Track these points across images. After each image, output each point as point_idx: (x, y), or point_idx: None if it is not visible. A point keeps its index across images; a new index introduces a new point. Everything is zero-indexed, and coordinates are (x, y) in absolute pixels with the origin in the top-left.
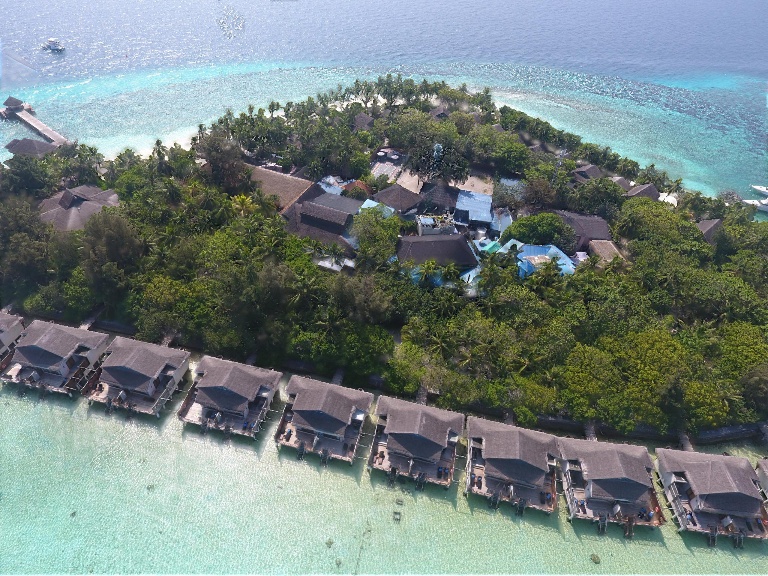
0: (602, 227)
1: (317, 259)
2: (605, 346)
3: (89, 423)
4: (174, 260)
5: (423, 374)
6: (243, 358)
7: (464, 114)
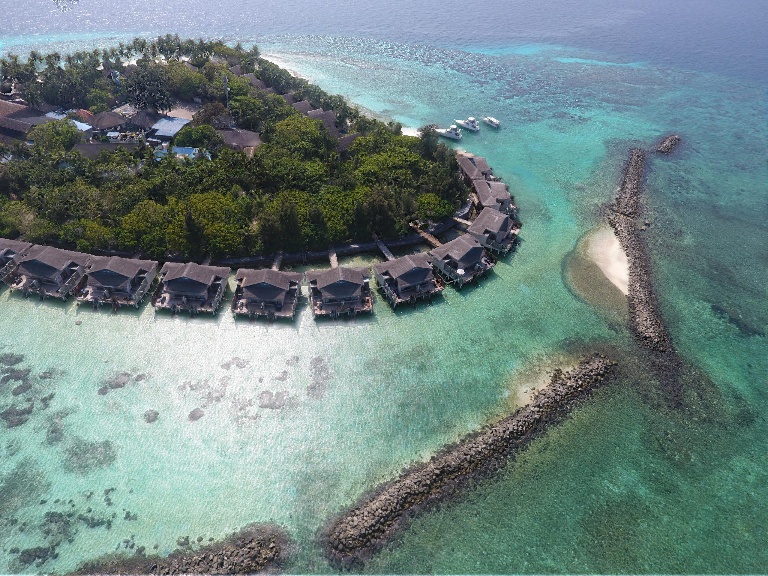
0: None
1: None
2: (168, 202)
3: None
4: None
5: (14, 219)
6: None
7: (217, 64)
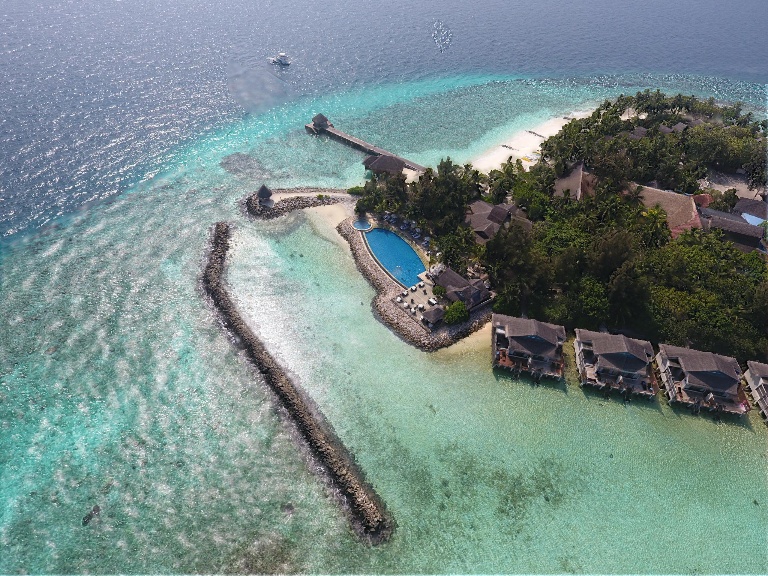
0: None
1: None
2: None
3: (686, 422)
4: (671, 273)
5: None
6: (766, 363)
7: None
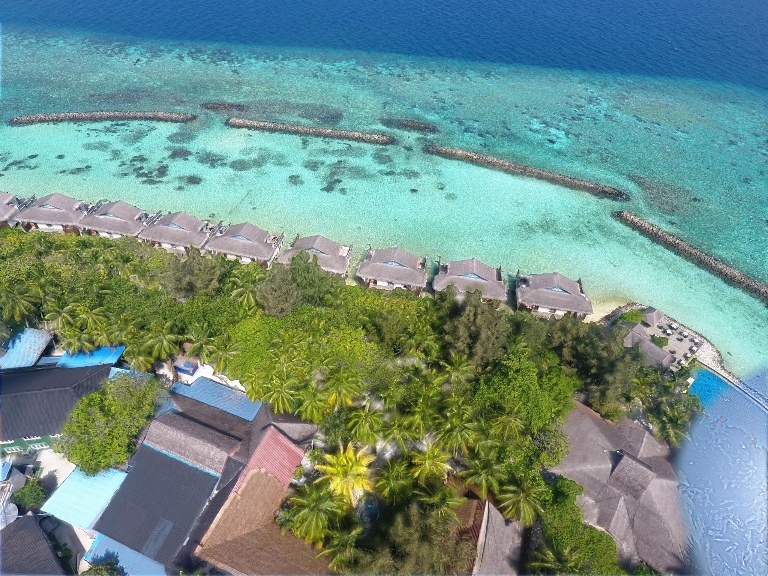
0: None
1: None
2: None
3: None
4: None
5: (157, 249)
6: None
7: None
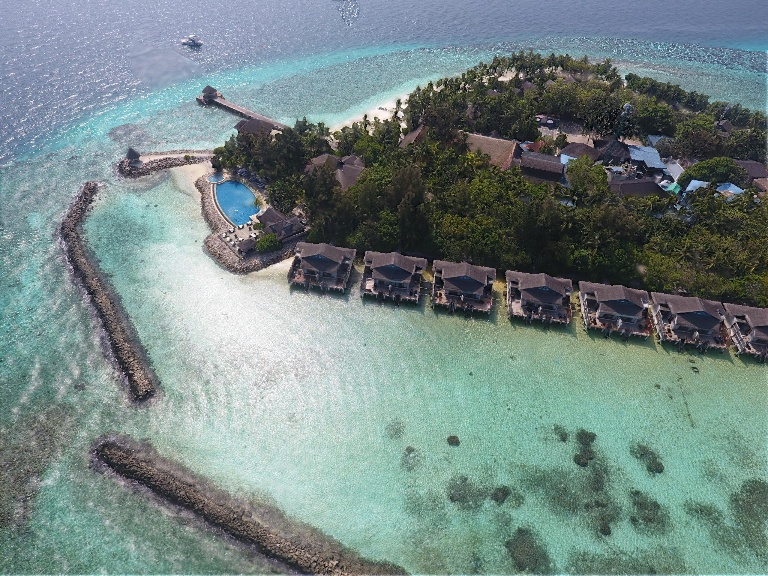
0: (761, 168)
1: (559, 199)
2: None
3: (441, 320)
4: (457, 202)
5: (680, 275)
6: None
7: (600, 82)
